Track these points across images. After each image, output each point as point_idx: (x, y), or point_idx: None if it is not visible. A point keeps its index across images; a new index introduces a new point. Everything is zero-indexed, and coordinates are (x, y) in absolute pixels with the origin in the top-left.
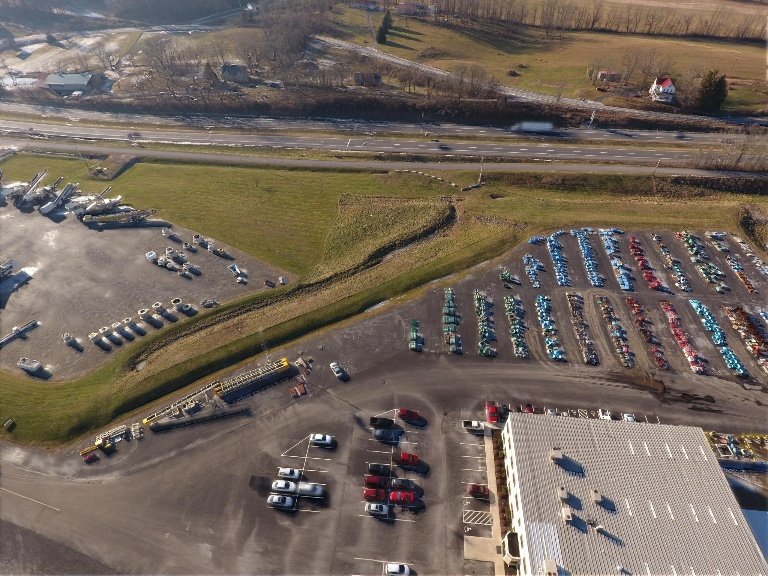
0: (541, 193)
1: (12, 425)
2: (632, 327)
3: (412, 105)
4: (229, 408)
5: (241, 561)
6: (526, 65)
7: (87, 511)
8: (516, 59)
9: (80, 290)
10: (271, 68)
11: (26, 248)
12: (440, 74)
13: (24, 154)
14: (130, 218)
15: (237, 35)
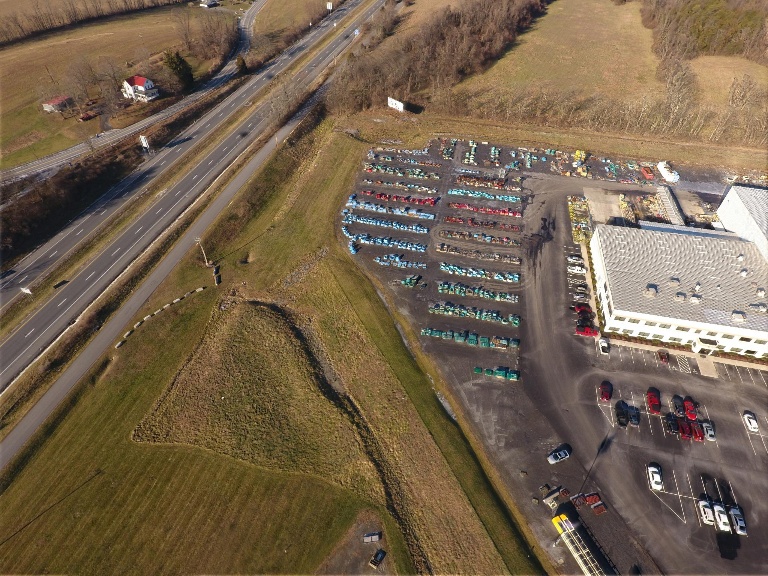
0: (257, 225)
1: None
2: (478, 229)
3: None
4: None
5: None
6: None
7: None
8: None
9: None
10: None
11: None
12: None
13: None
14: None
15: None
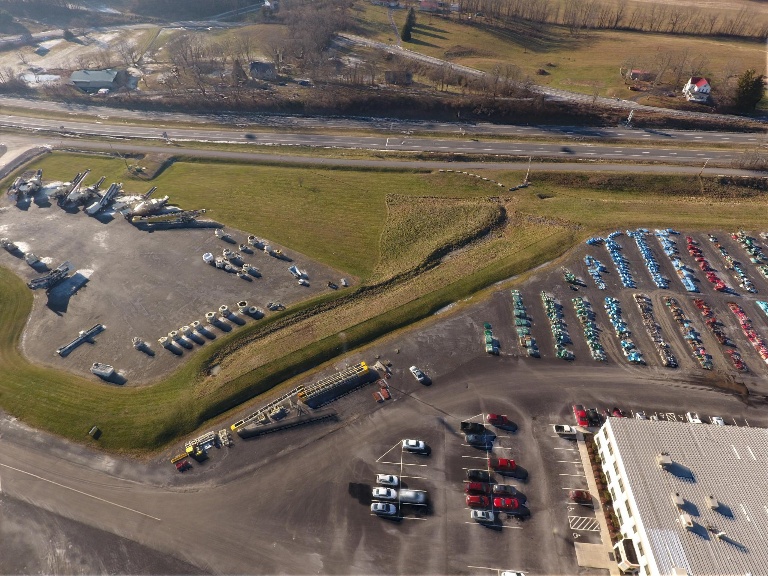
0: (588, 193)
1: (97, 432)
2: (704, 329)
3: (447, 104)
4: (315, 413)
5: (354, 571)
6: (554, 64)
7: (189, 521)
8: (543, 58)
9: (140, 293)
10: (297, 66)
11: (78, 249)
12: (471, 72)
13: (59, 153)
14: (180, 219)
15: (262, 32)
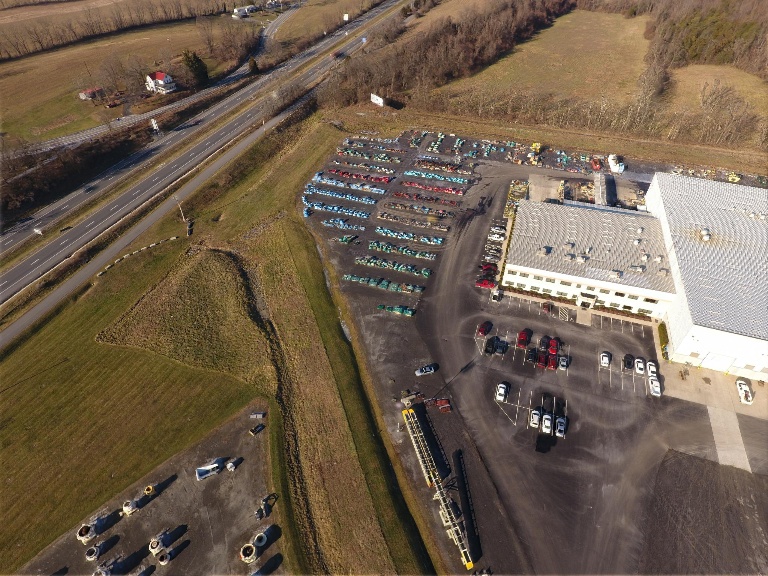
0: (234, 193)
1: None
2: (420, 203)
3: None
4: (457, 472)
5: (612, 460)
6: None
7: None
8: None
9: None
10: None
11: None
12: None
13: None
14: None
15: None
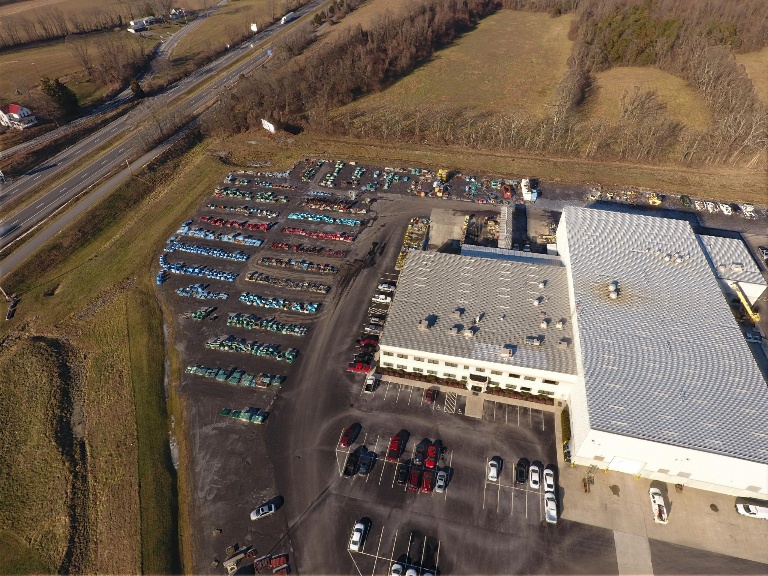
0: (81, 254)
1: None
2: (301, 255)
3: None
4: None
5: None
6: None
7: None
8: None
9: None
10: None
11: None
12: None
13: None
14: None
15: None
